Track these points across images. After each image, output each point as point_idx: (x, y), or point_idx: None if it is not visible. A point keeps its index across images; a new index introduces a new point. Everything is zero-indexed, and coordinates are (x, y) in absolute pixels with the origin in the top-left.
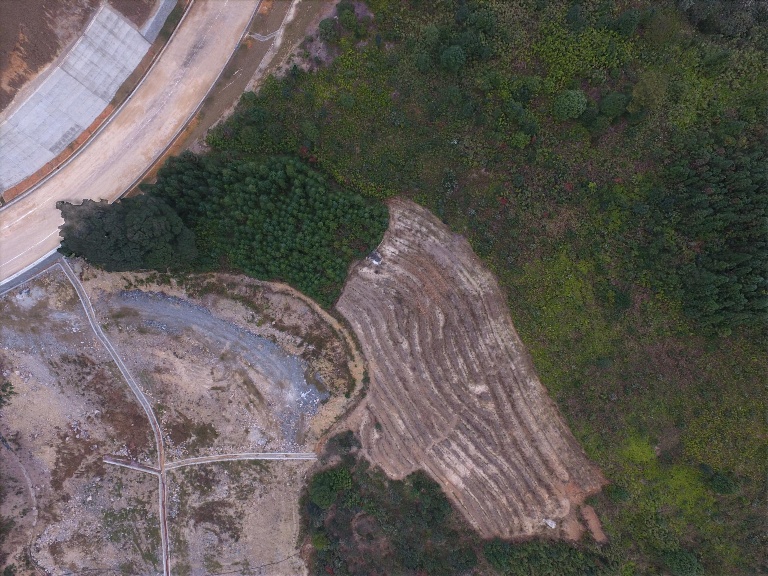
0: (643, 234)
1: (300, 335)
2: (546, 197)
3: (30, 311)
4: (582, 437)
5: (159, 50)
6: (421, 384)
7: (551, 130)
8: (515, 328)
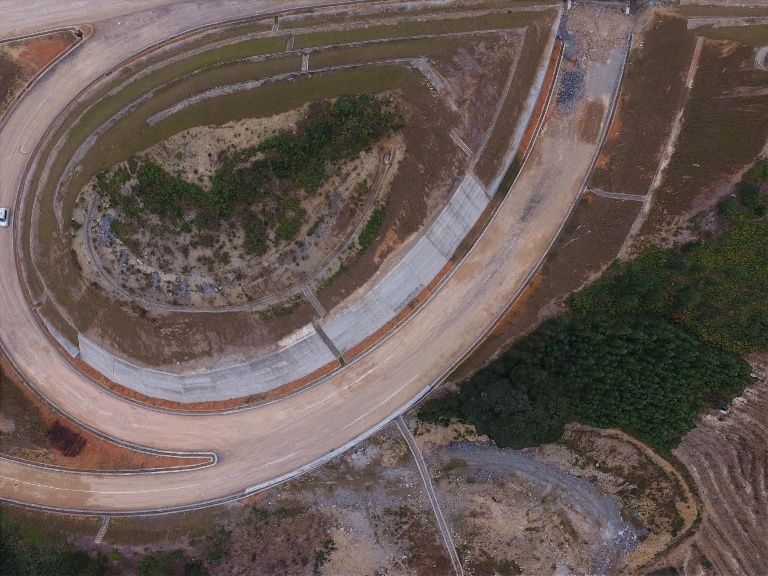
0: None
1: (623, 475)
2: None
3: (364, 470)
4: None
5: (497, 205)
6: (764, 526)
7: None
8: None
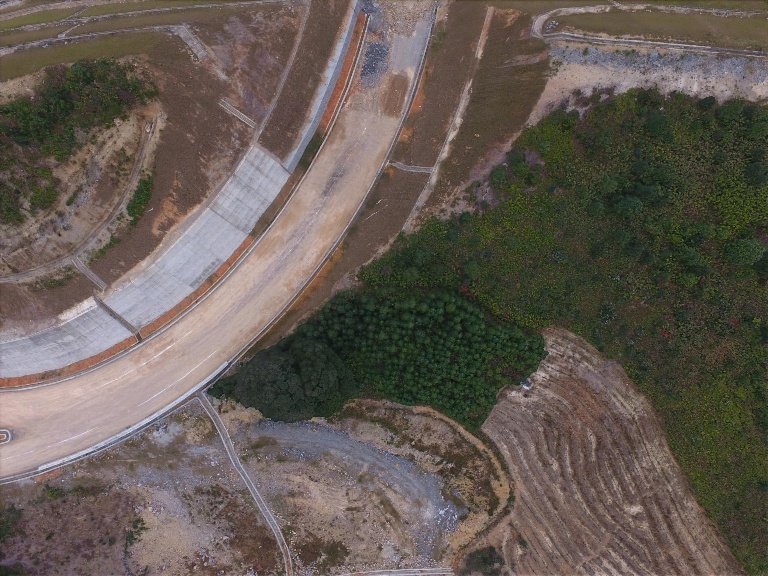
0: None
1: (440, 454)
2: (707, 329)
3: (167, 447)
4: (745, 558)
5: (298, 179)
6: (572, 504)
7: (718, 270)
8: (671, 451)
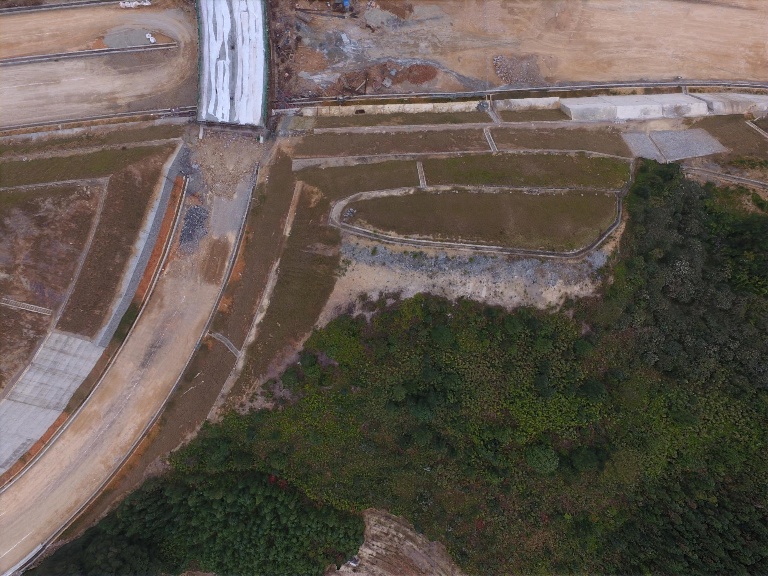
0: (620, 560)
1: None
2: (522, 520)
3: None
4: None
5: (114, 352)
6: None
7: (524, 468)
8: None
